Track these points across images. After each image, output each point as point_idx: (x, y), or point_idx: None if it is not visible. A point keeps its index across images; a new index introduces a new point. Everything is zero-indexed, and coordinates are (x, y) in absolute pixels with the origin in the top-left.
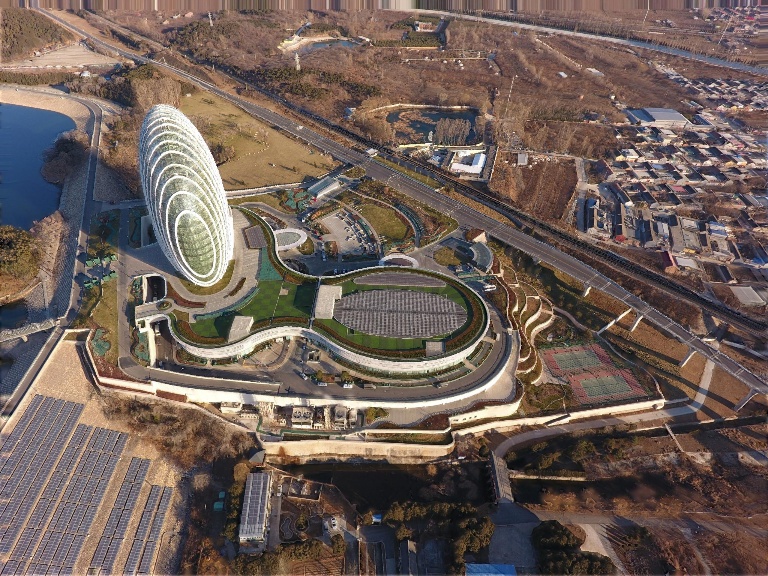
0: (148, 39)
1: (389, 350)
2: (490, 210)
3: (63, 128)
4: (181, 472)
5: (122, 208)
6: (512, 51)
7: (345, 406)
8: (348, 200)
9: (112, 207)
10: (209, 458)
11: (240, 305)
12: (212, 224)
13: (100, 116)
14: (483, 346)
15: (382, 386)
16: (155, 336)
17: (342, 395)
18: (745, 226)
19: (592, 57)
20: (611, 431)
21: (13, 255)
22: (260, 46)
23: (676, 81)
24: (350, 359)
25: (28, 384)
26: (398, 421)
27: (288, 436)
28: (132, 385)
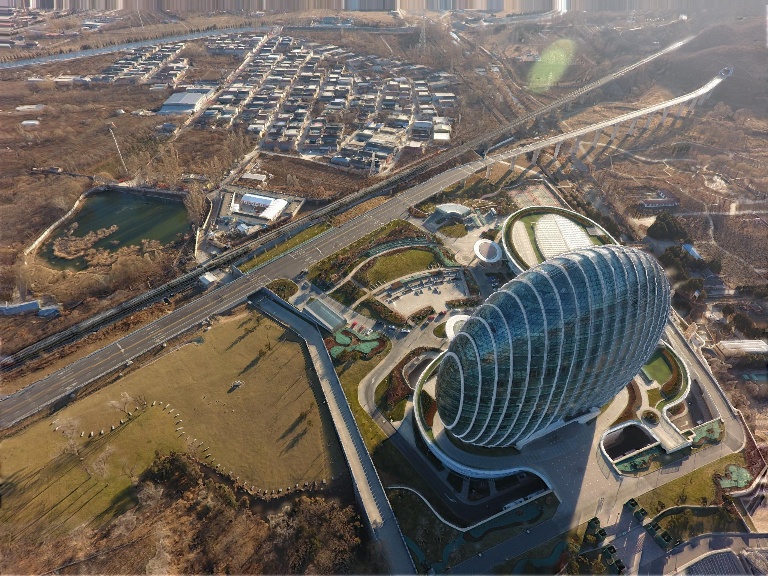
0: None
1: None
2: (366, 203)
3: None
4: None
5: None
6: None
7: None
8: None
9: None
10: None
11: None
12: None
13: None
14: None
15: None
16: None
17: None
18: (364, 118)
19: None
20: None
21: None
22: None
23: (103, 79)
24: None
25: None
26: None
27: None
28: None
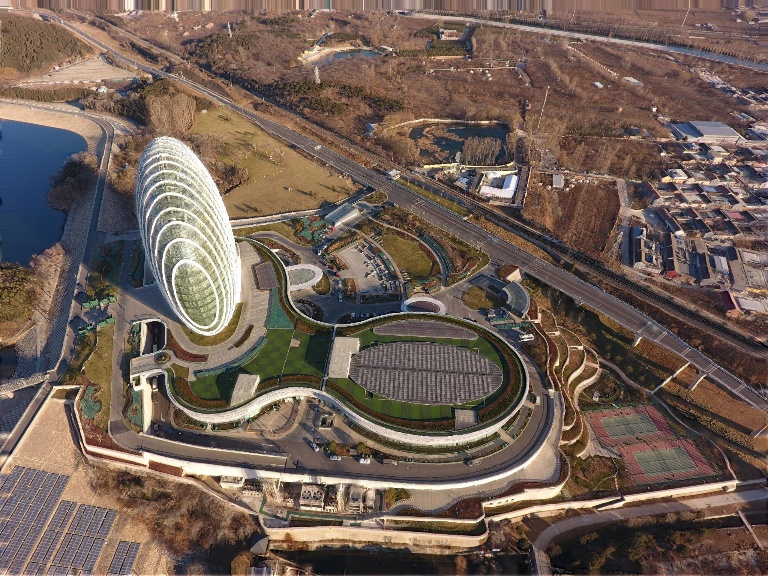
0: (167, 52)
1: (413, 420)
2: (524, 241)
3: (74, 148)
4: (174, 559)
5: (127, 239)
6: (543, 60)
7: (361, 485)
8: (368, 230)
9: (116, 238)
10: (205, 543)
11: (246, 359)
12: (214, 272)
13: (112, 136)
14: (521, 412)
15: (404, 462)
16: (152, 392)
17: (358, 472)
18: None
19: (629, 65)
20: (674, 520)
21: (6, 296)
22: (280, 57)
23: (723, 91)
24: (368, 427)
25: (7, 453)
26: (422, 506)
27: (295, 520)
28: (122, 456)
